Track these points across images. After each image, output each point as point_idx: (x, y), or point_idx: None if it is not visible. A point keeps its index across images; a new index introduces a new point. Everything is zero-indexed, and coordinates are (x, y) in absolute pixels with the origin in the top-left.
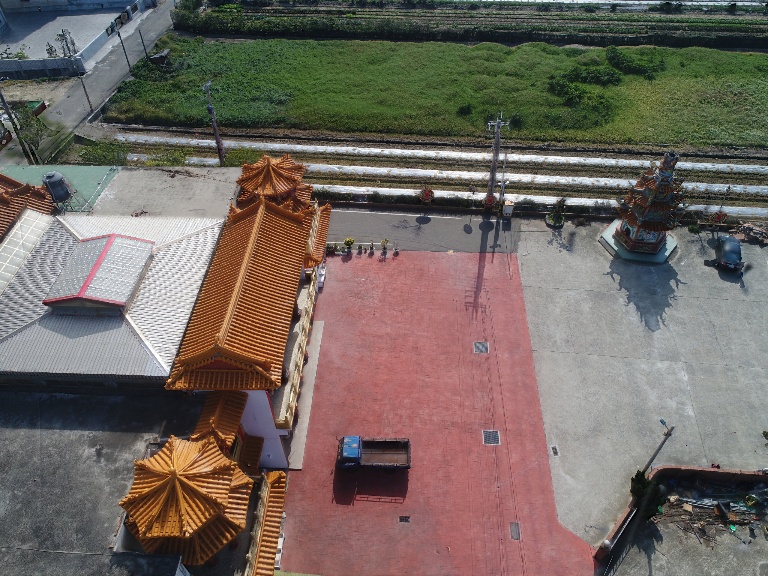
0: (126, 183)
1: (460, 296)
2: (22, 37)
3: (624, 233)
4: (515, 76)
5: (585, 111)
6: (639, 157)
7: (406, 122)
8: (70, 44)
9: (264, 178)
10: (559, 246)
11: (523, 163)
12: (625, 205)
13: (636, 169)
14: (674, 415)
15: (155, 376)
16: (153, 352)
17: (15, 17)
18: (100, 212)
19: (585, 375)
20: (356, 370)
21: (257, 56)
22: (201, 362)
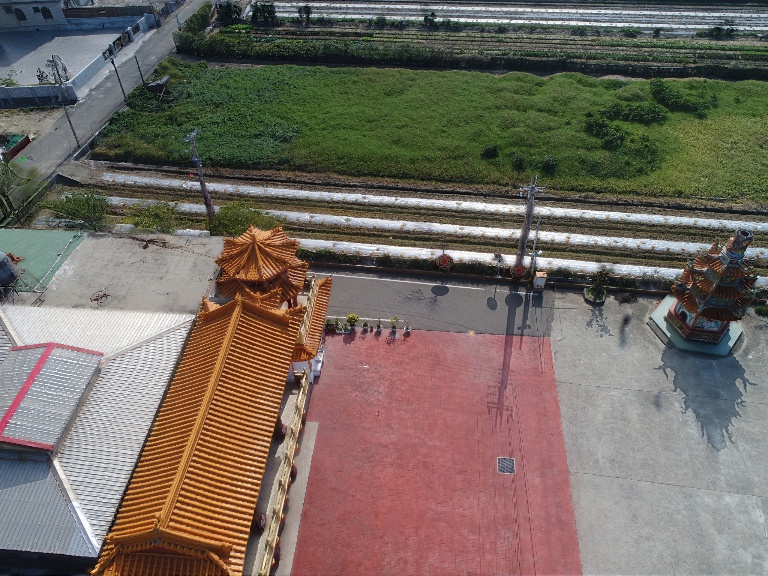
0: (90, 255)
1: (481, 393)
2: (15, 60)
3: (679, 317)
4: (547, 112)
5: (628, 156)
6: (691, 214)
7: (424, 166)
8: (61, 70)
9: (248, 259)
10: (600, 329)
11: (556, 218)
12: (682, 286)
13: (688, 229)
14: (750, 574)
15: (81, 555)
16: (82, 519)
17: (11, 37)
18: (54, 293)
19: (635, 510)
20: (353, 492)
21: (263, 84)
22: (138, 546)
